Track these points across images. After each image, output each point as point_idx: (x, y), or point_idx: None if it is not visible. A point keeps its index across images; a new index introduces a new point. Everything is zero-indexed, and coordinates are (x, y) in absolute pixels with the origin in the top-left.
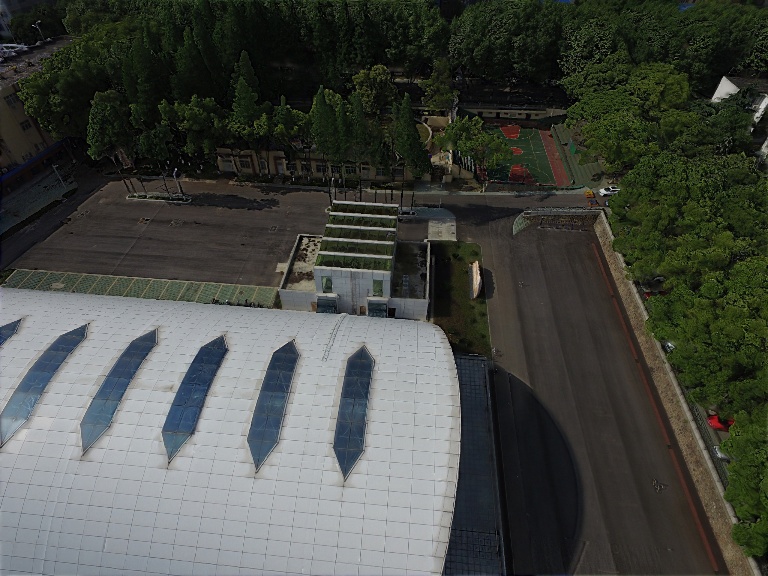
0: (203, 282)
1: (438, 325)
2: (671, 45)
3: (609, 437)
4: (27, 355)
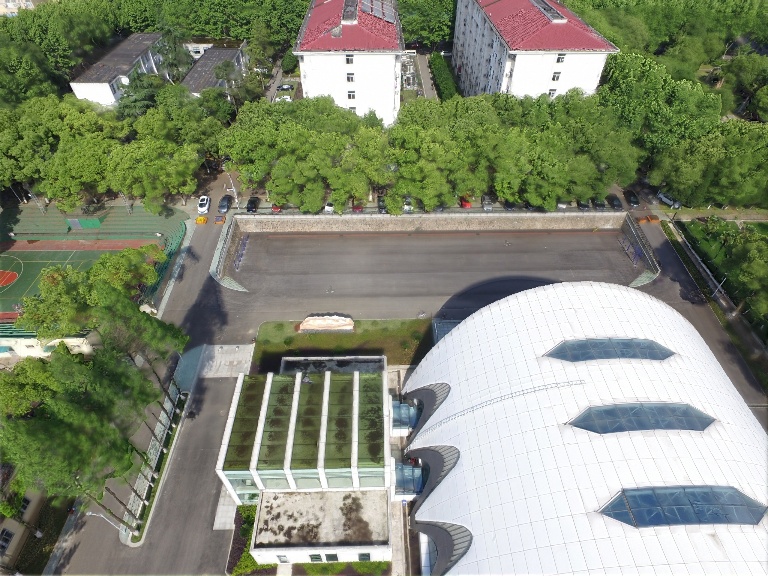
0: None
1: (396, 361)
2: (5, 82)
3: (482, 259)
4: None
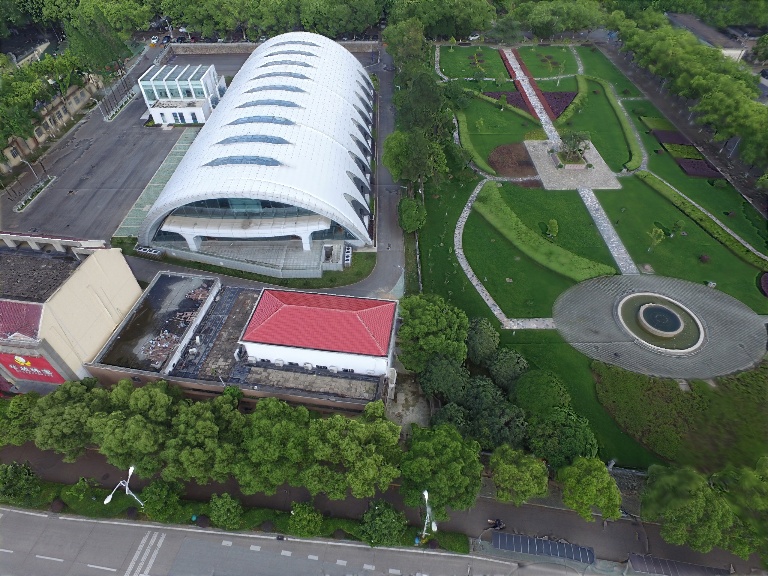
0: (170, 151)
1: None
2: None
3: None
4: (264, 93)
